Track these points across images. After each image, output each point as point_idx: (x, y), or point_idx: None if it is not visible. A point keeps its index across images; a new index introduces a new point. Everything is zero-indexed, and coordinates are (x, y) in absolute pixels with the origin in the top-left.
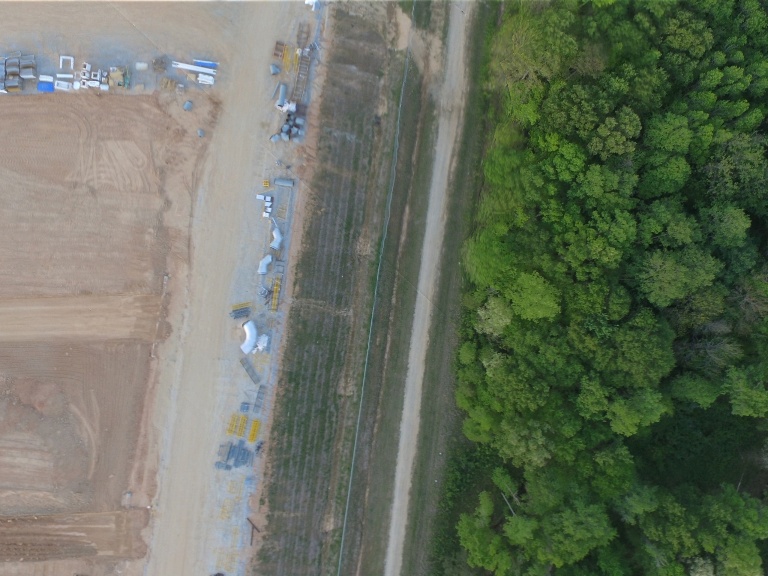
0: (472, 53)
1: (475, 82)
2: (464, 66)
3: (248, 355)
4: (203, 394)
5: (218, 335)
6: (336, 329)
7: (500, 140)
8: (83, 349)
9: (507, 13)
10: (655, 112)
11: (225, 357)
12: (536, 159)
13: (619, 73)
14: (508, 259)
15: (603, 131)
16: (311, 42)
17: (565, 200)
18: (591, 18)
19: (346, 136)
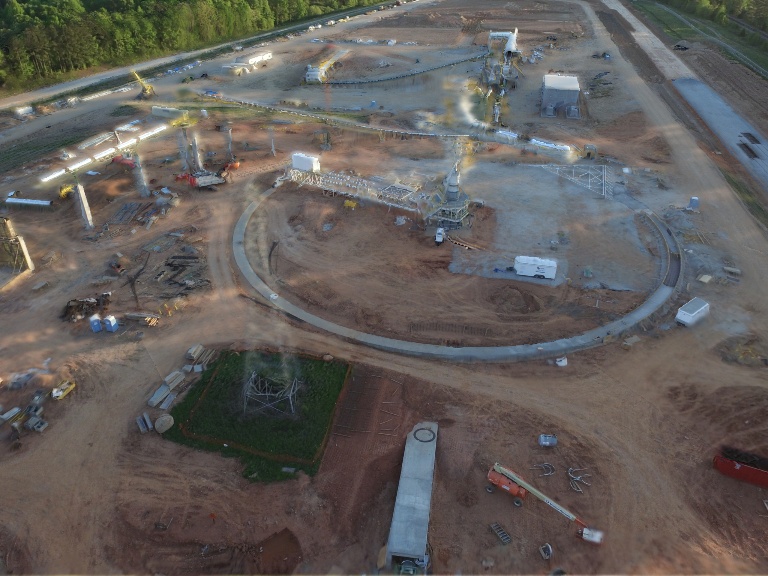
0: None
1: None
2: None
3: None
4: None
5: None
6: None
7: None
8: None
9: None
10: None
11: None
12: (218, 4)
13: None
14: None
15: None
16: None
17: None
18: None
19: None
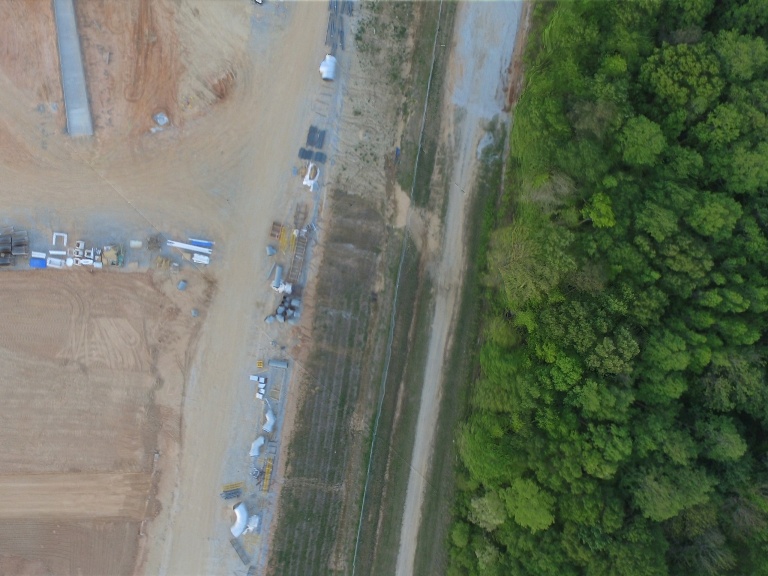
0: (471, 232)
1: (473, 261)
2: (462, 245)
3: (238, 537)
4: (192, 573)
5: (208, 514)
6: (328, 504)
7: (497, 341)
8: (71, 527)
9: (507, 195)
10: (653, 336)
11: (215, 537)
12: (533, 367)
13: (618, 296)
14: (502, 462)
15: (601, 351)
16: (308, 223)
17: (561, 408)
18: (591, 237)
19: (342, 314)
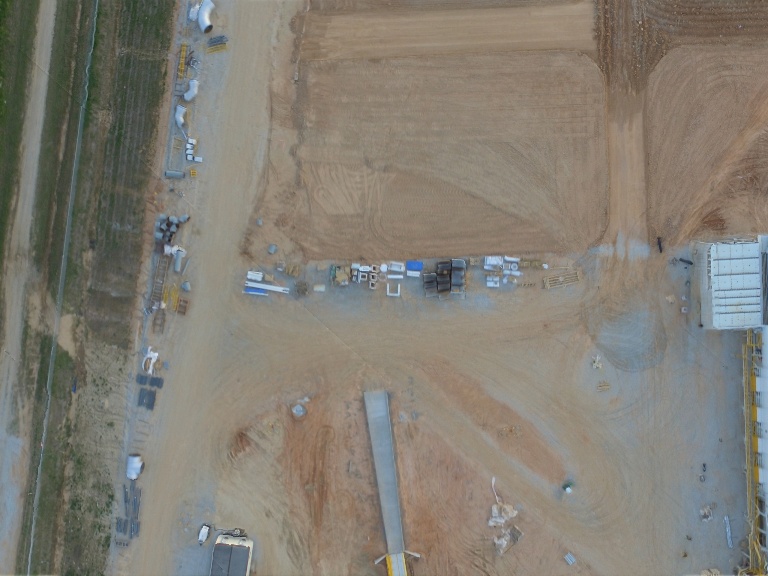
0: None
1: None
2: (6, 300)
3: None
4: None
5: (242, 20)
6: (131, 34)
7: None
8: (378, 4)
9: None
10: None
11: None
12: None
13: None
14: None
15: None
16: (152, 315)
17: None
18: None
19: (121, 226)
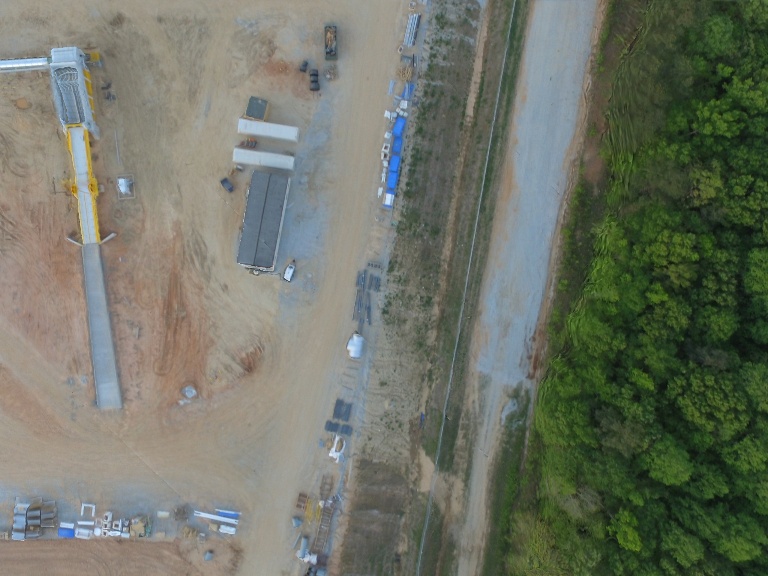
0: (494, 495)
1: (496, 524)
2: (485, 508)
3: None
4: None
5: None
6: None
7: None
8: None
9: (530, 463)
10: None
11: None
12: None
13: None
14: None
15: None
16: (334, 494)
17: None
18: (618, 557)
19: None
